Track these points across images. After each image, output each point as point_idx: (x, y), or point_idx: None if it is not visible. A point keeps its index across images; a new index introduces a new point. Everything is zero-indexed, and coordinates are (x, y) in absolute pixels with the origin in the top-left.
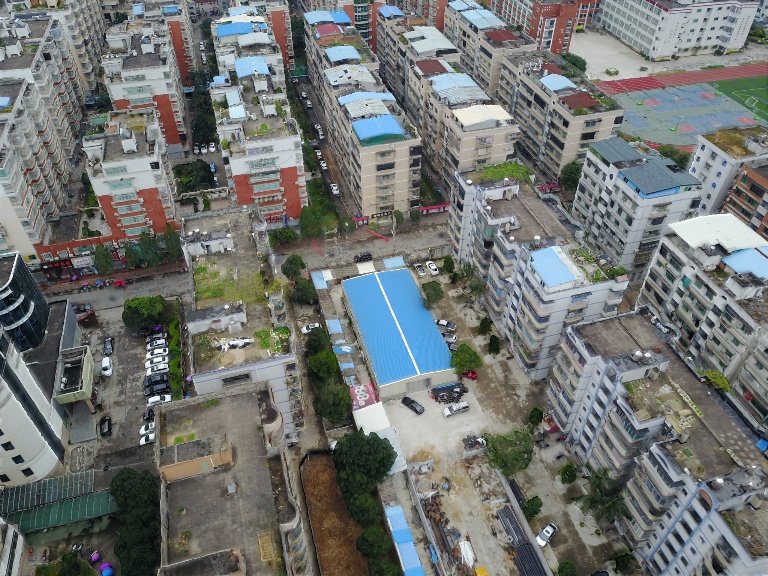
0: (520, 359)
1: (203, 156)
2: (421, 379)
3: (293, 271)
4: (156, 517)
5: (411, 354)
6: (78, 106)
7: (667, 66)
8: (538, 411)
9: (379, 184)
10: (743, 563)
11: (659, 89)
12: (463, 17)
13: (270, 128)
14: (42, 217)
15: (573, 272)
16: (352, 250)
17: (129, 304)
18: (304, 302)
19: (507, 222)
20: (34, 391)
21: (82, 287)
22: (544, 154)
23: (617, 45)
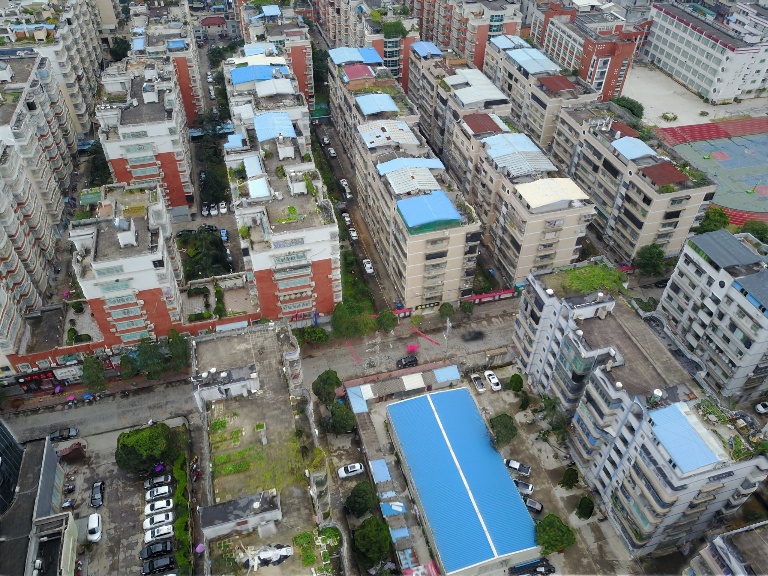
0: (622, 532)
1: (213, 219)
2: (498, 561)
3: (327, 393)
4: None
5: (483, 523)
6: (68, 157)
7: (729, 110)
8: None
9: (427, 274)
10: None
11: (725, 139)
12: (509, 57)
13: (300, 212)
14: (19, 317)
15: (712, 448)
16: (393, 351)
17: (124, 442)
18: (341, 432)
19: (605, 353)
20: None
21: (67, 402)
22: (613, 229)
23: (669, 83)
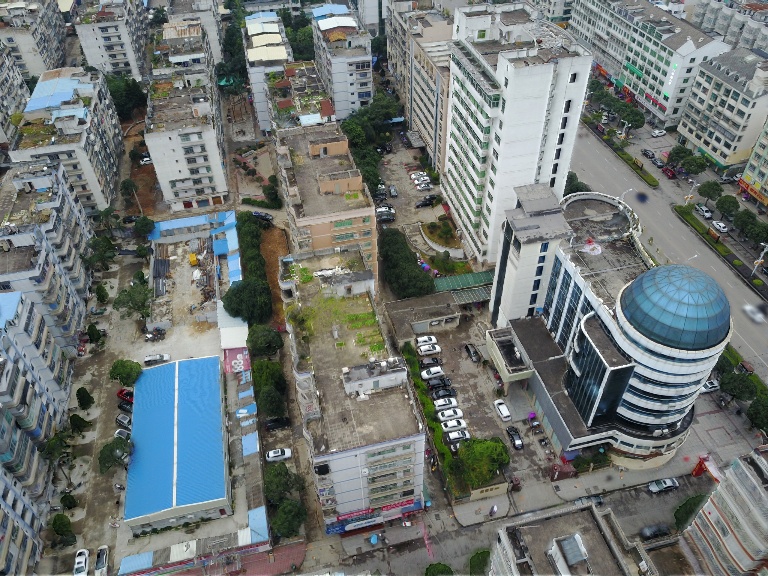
0: None
1: None
2: None
3: None
4: (391, 257)
5: (176, 382)
6: None
7: None
8: (92, 325)
9: None
10: (64, 169)
11: None
12: None
13: None
14: None
15: None
16: None
17: (497, 444)
18: None
19: None
20: None
21: None
22: None
23: None
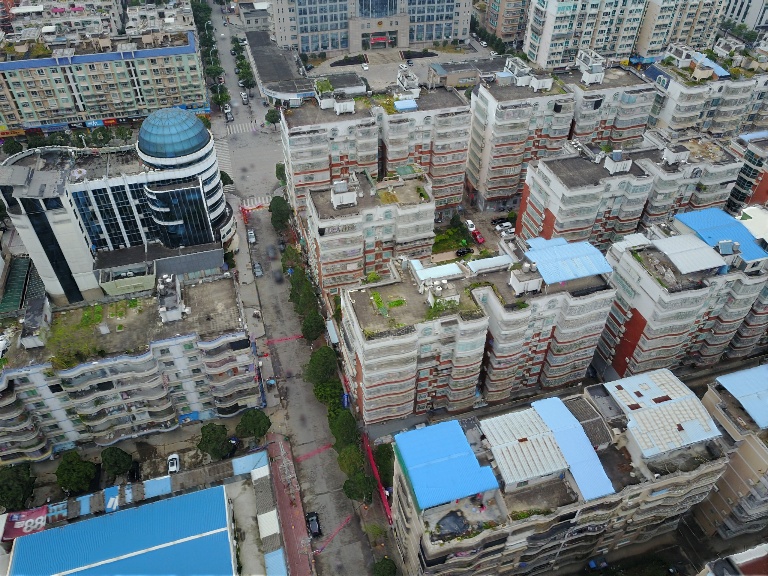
0: None
1: None
2: None
3: None
4: None
5: None
6: None
7: None
8: None
9: None
10: None
11: None
12: None
13: (395, 310)
14: None
15: None
16: (336, 510)
17: None
18: None
19: None
20: (72, 249)
21: None
22: None
23: None
